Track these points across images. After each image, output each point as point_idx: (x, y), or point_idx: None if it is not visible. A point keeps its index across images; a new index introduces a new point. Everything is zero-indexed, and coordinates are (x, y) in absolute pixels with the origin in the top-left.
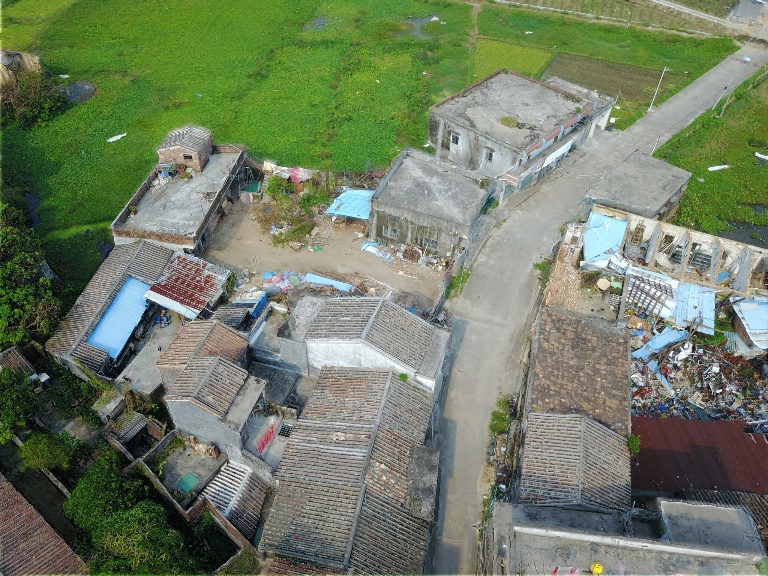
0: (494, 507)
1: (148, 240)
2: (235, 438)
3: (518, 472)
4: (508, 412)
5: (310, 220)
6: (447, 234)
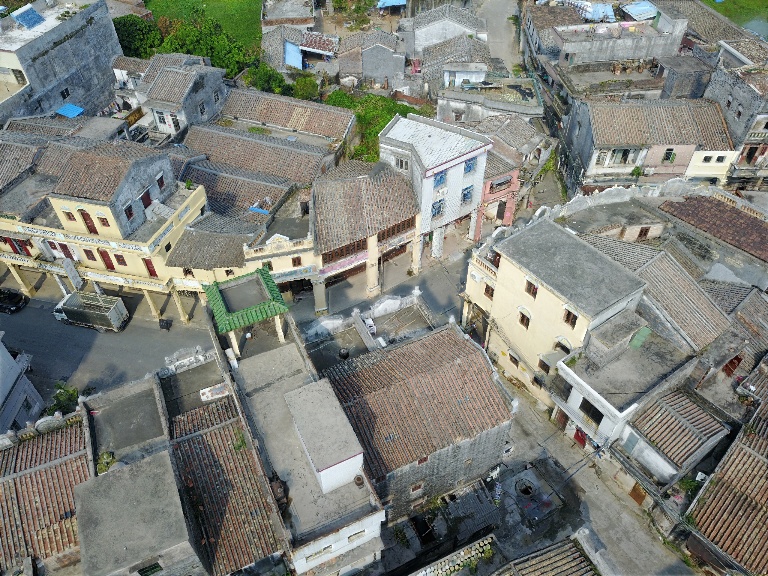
0: (537, 56)
1: (285, 25)
2: (402, 63)
3: None
4: (521, 68)
5: (366, 17)
6: (457, 1)
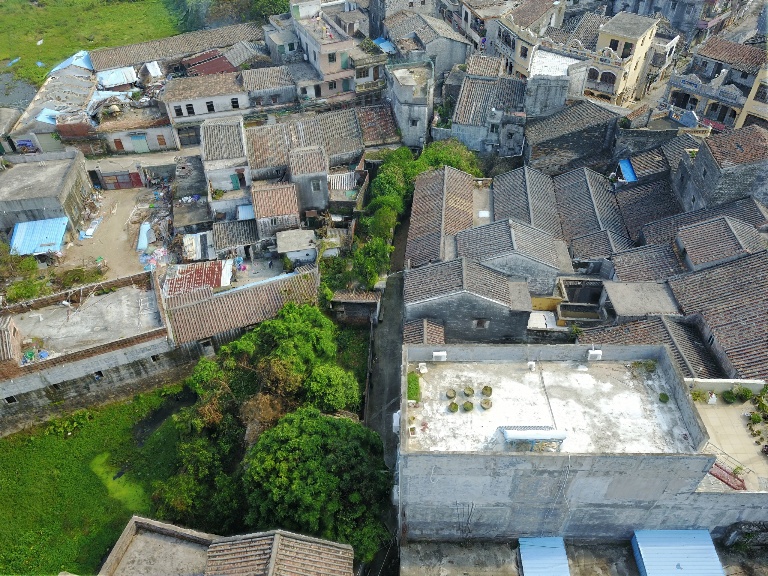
0: None
1: None
2: None
3: (275, 97)
4: None
5: None
6: (81, 171)
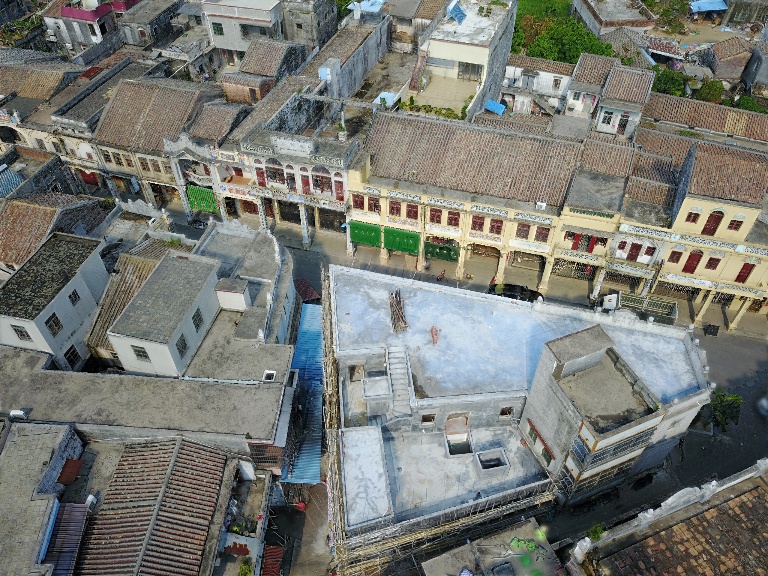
0: None
1: (625, 27)
2: None
3: None
4: None
5: None
6: None
